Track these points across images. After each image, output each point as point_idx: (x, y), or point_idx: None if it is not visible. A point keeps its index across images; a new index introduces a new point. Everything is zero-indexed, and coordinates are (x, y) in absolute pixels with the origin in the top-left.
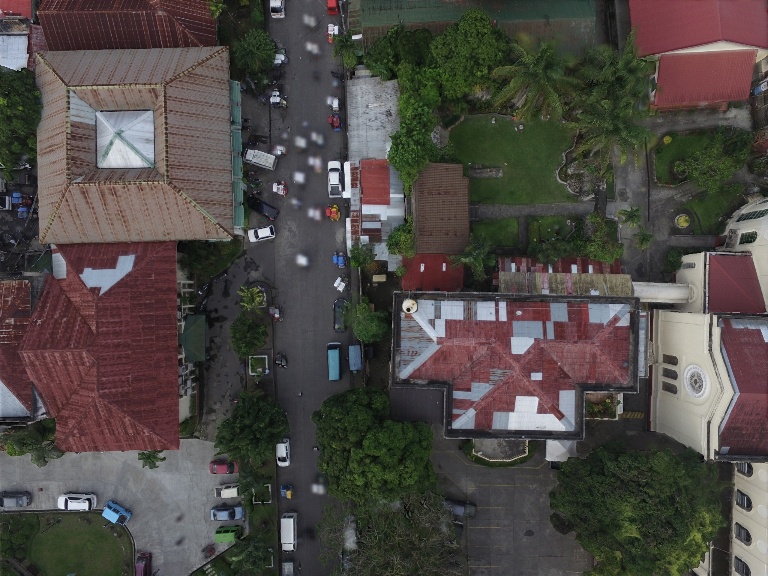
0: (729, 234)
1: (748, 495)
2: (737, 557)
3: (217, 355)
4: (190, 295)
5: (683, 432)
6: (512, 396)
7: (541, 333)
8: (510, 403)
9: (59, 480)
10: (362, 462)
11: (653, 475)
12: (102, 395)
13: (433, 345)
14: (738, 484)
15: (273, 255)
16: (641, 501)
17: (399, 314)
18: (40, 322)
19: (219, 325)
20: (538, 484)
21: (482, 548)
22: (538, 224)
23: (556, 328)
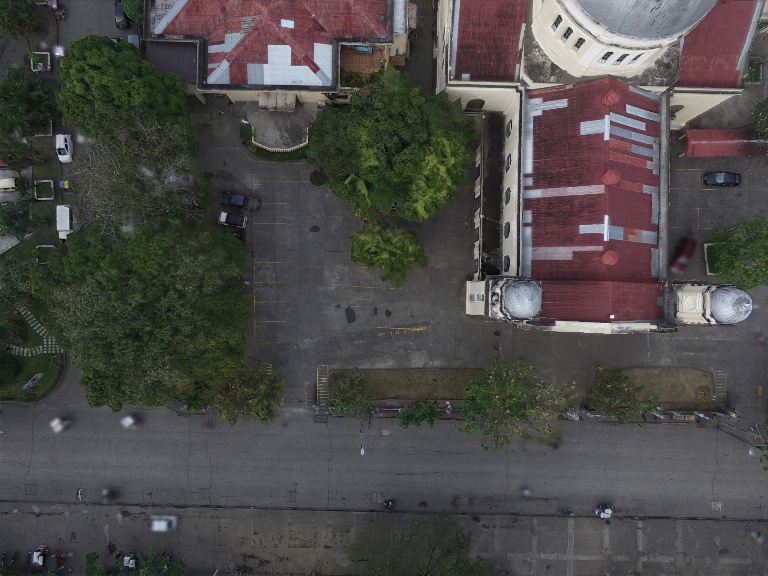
0: None
1: (510, 152)
2: (505, 223)
3: (2, 56)
4: None
5: None
6: (264, 45)
7: None
8: (262, 53)
9: None
10: (84, 72)
11: (383, 90)
12: None
13: None
14: (506, 151)
15: None
16: (375, 122)
17: None
18: None
19: None
20: None
21: (267, 244)
22: None
23: None
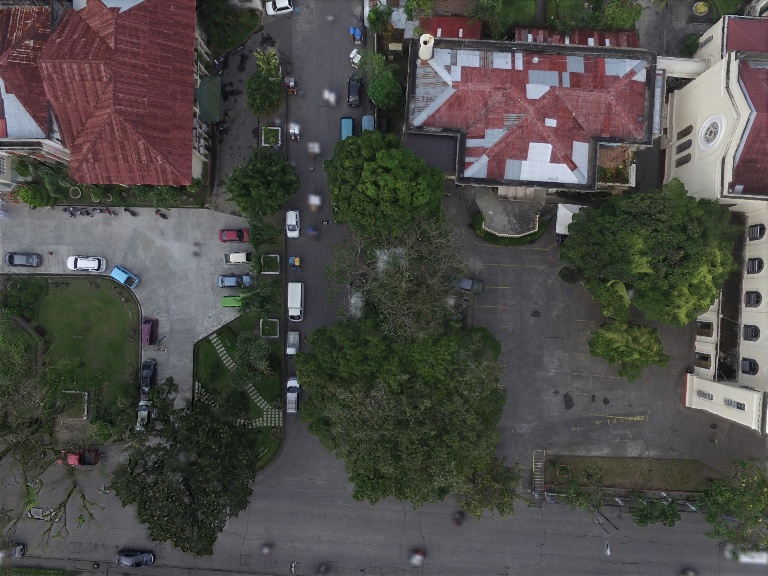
0: (748, 9)
1: (760, 257)
2: (746, 325)
3: (230, 128)
4: (206, 64)
5: (696, 190)
6: (525, 142)
7: (557, 82)
8: (523, 150)
9: (69, 244)
10: (375, 173)
11: (666, 202)
12: (118, 110)
13: (448, 89)
14: (749, 252)
15: (290, 31)
16: (653, 231)
17: (415, 62)
18: (59, 40)
19: (234, 98)
20: (547, 265)
21: (488, 327)
22: (556, 3)
23: (572, 78)
